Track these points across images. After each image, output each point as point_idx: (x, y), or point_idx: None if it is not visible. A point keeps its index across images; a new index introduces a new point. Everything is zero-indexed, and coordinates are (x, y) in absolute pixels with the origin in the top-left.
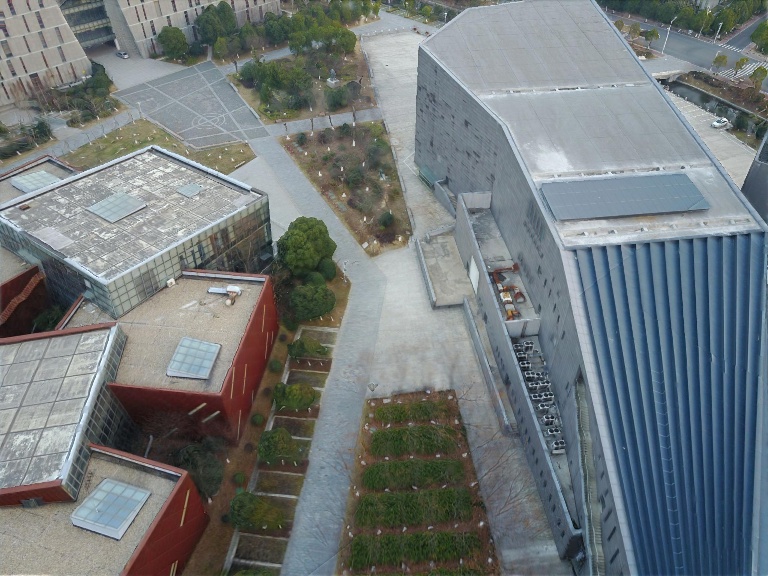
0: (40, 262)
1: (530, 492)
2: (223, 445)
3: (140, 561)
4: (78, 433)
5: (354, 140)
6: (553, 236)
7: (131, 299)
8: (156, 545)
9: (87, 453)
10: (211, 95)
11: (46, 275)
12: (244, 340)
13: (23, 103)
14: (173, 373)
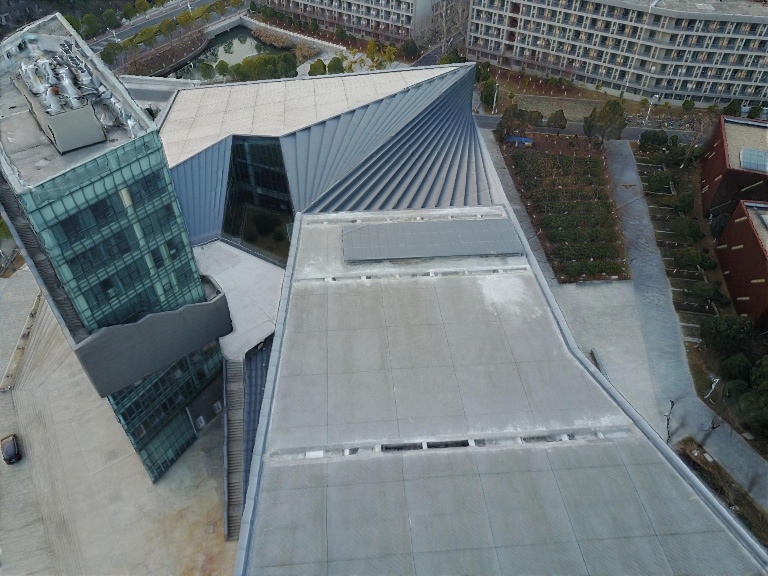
0: None
1: None
2: None
3: None
4: None
5: None
6: None
7: None
8: None
9: None
10: None
11: None
12: None
13: None
14: None
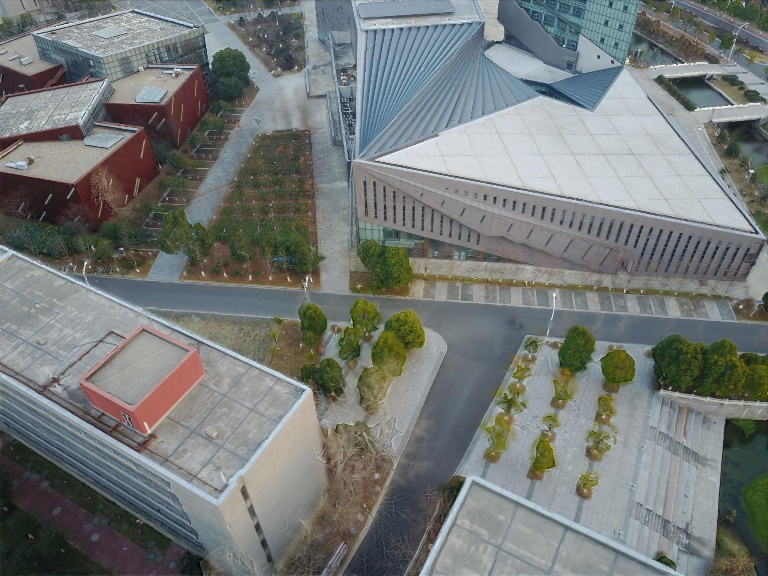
0: (64, 60)
1: (341, 165)
2: (169, 144)
3: (118, 155)
4: (87, 111)
5: (277, 20)
6: (356, 25)
7: (117, 73)
8: (127, 155)
9: (92, 124)
10: (181, 1)
11: (68, 69)
12: (180, 88)
13: (46, 10)
14: (139, 100)
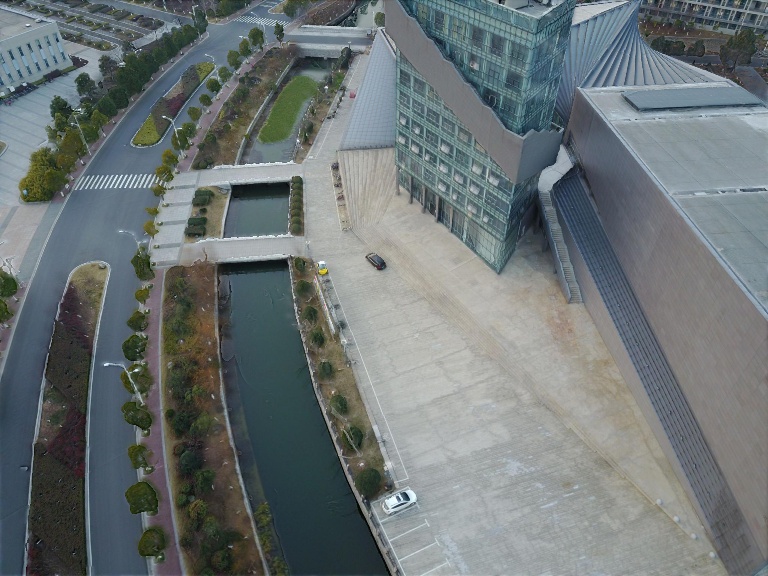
0: None
1: None
2: None
3: None
4: None
5: None
6: None
7: None
8: None
9: None
10: None
11: None
12: None
13: None
14: None
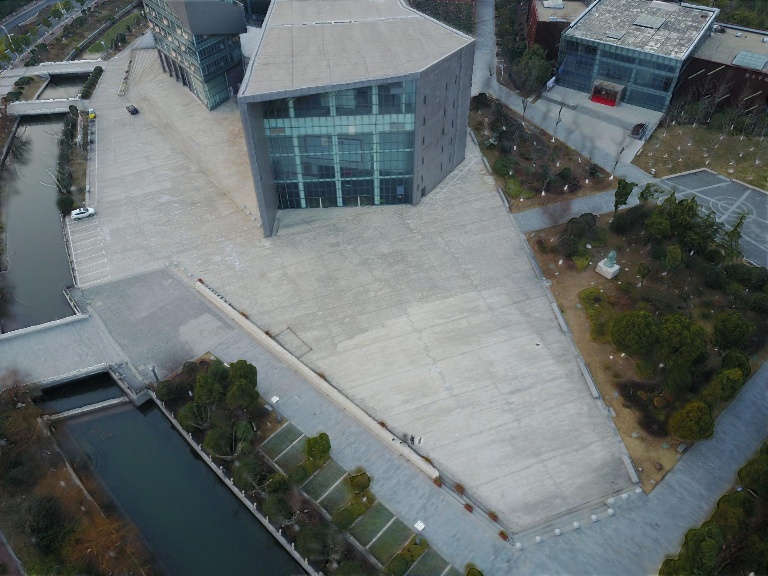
0: None
1: None
2: None
3: None
4: None
5: None
6: None
7: None
8: None
9: None
10: None
11: None
12: None
13: None
14: None
